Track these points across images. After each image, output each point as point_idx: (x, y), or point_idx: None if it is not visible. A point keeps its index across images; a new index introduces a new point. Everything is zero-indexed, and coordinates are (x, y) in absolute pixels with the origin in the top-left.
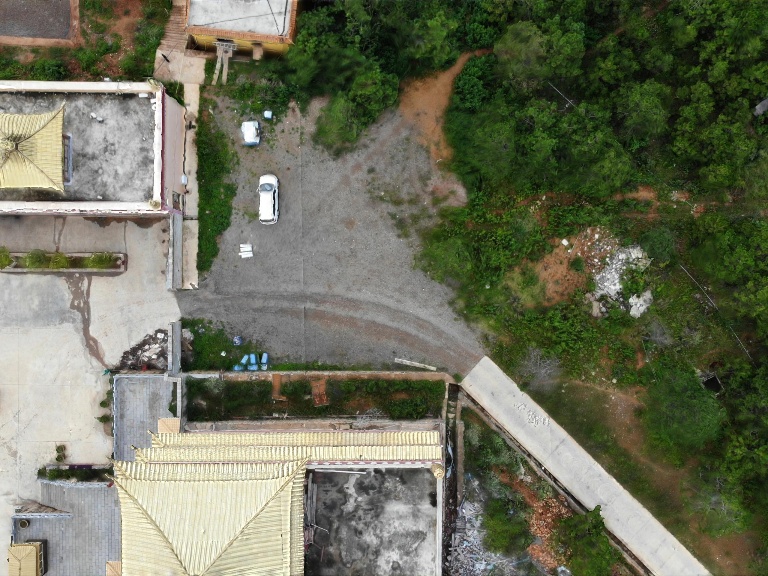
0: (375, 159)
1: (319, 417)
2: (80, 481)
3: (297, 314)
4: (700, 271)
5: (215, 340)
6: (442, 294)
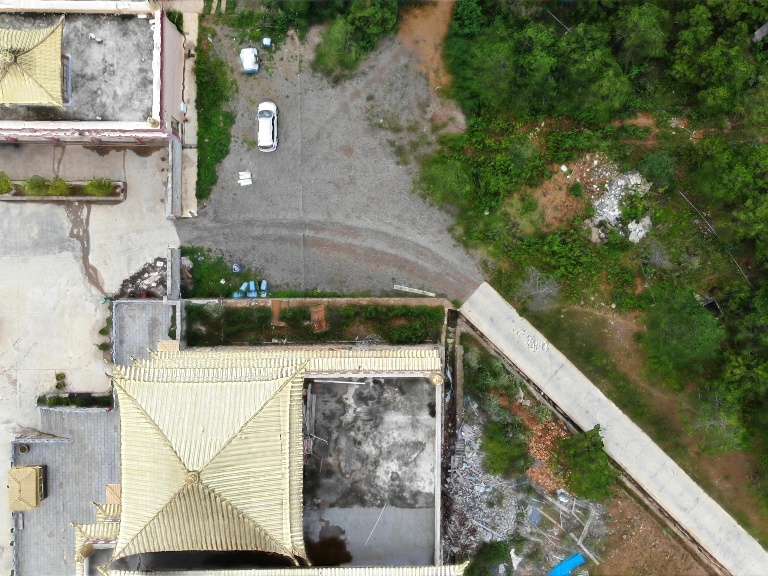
0: (374, 87)
1: (318, 343)
2: (80, 407)
3: (296, 241)
4: (699, 194)
5: (214, 268)
6: (441, 220)
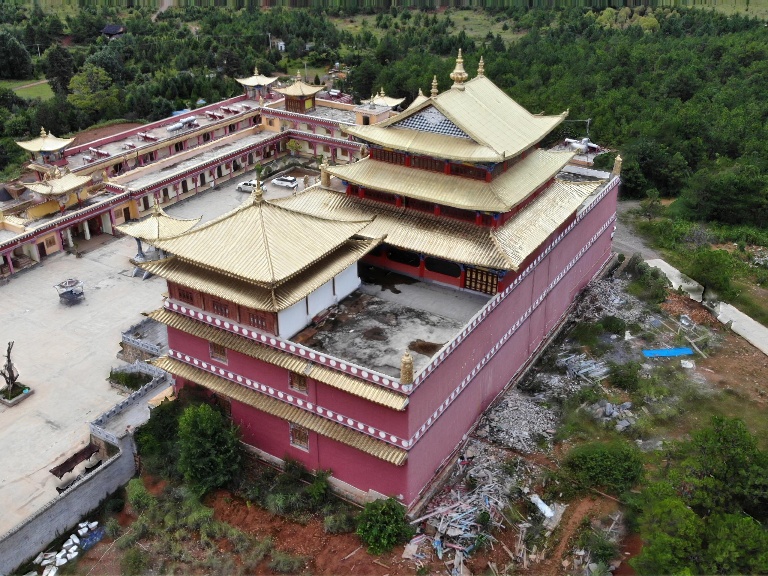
0: None
1: None
2: None
3: None
4: None
5: None
6: None
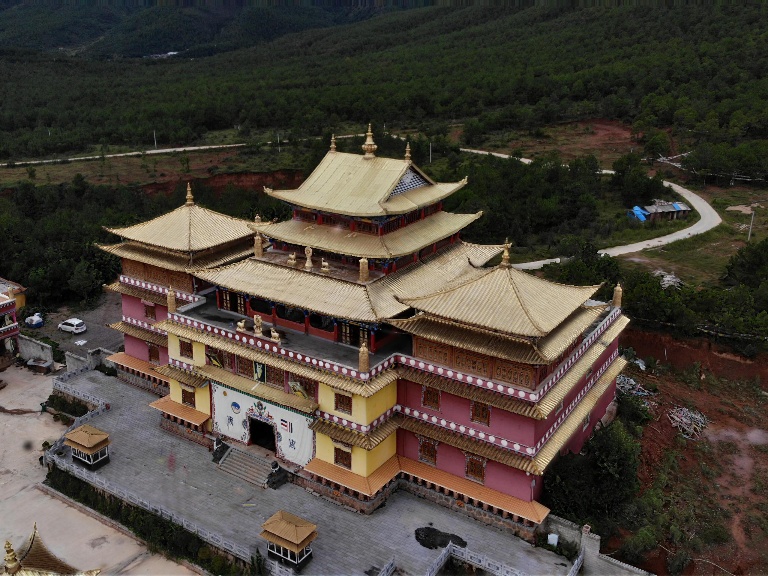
0: (115, 302)
1: None
2: None
3: None
4: None
5: None
6: None
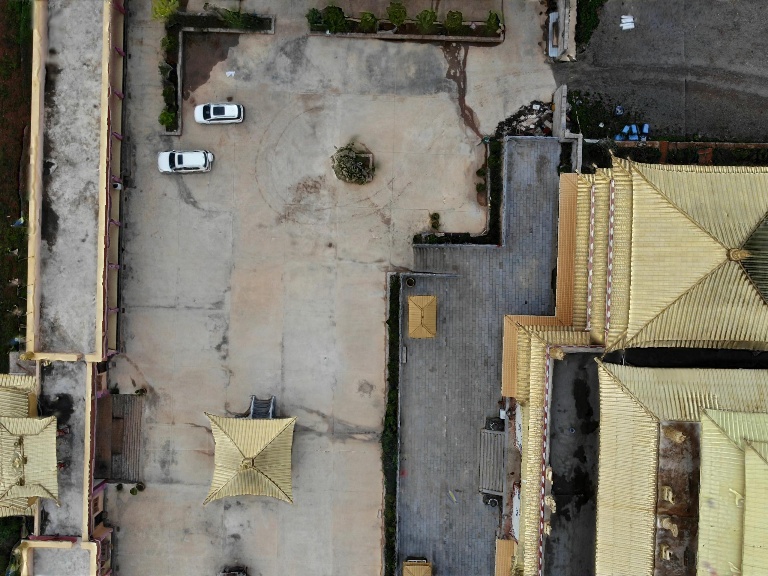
0: None
1: None
2: (466, 242)
3: (677, 87)
4: None
5: (593, 112)
6: None
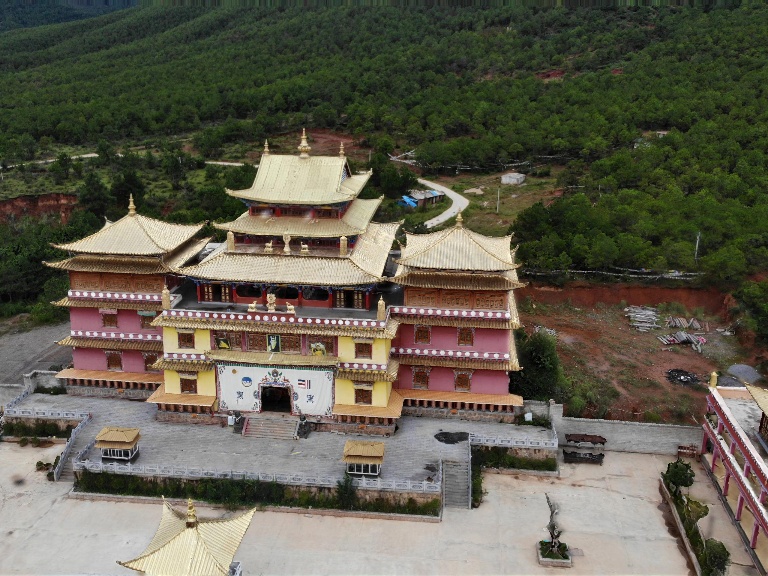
0: None
1: None
2: None
3: (40, 364)
4: None
5: None
6: None
